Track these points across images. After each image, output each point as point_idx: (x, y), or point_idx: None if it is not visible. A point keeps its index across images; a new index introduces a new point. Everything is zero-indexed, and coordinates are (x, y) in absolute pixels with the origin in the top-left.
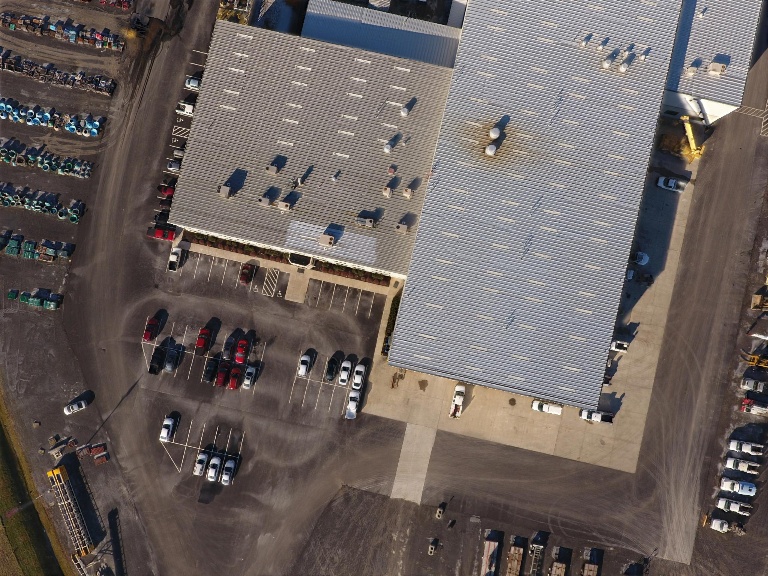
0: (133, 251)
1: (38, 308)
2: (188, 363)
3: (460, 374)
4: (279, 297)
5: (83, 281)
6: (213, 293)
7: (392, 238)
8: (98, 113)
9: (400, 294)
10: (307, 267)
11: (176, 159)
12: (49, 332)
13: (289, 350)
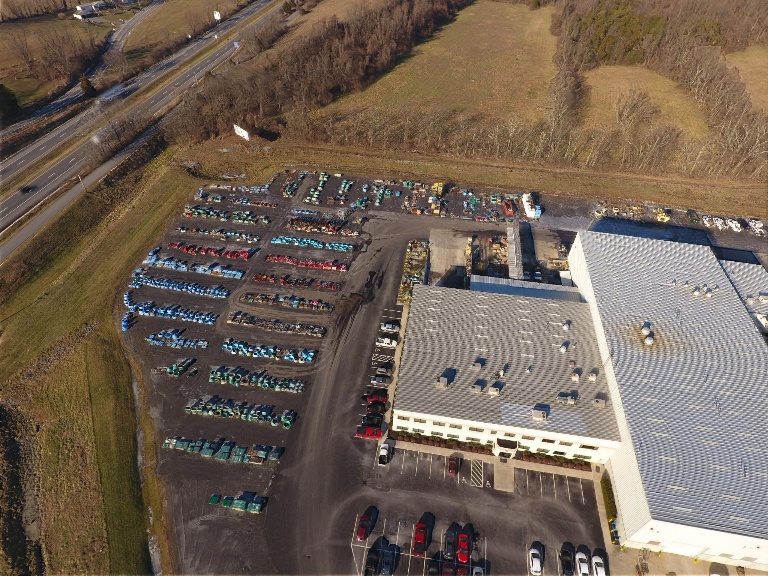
0: (341, 450)
1: (239, 513)
2: (405, 567)
3: (729, 525)
4: (488, 487)
5: (290, 482)
6: (422, 487)
7: (594, 412)
8: (312, 348)
9: (606, 477)
10: (513, 452)
11: (377, 376)
12: (248, 539)
13: (513, 544)
